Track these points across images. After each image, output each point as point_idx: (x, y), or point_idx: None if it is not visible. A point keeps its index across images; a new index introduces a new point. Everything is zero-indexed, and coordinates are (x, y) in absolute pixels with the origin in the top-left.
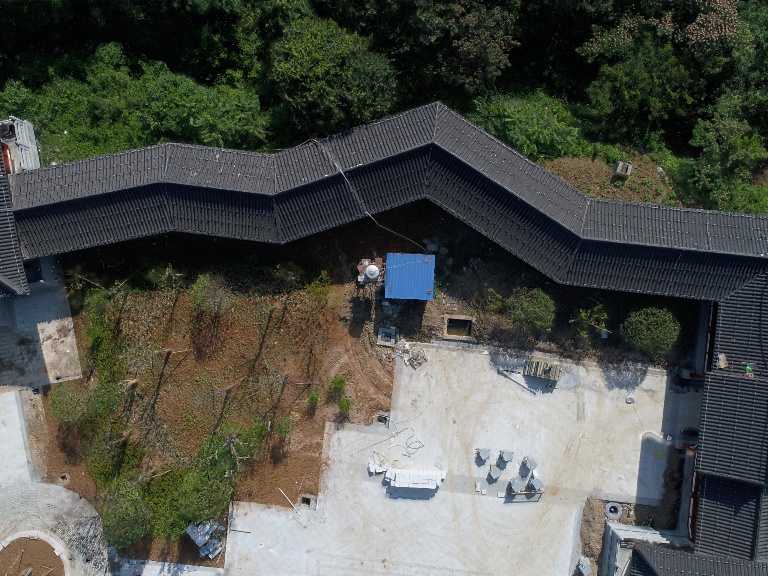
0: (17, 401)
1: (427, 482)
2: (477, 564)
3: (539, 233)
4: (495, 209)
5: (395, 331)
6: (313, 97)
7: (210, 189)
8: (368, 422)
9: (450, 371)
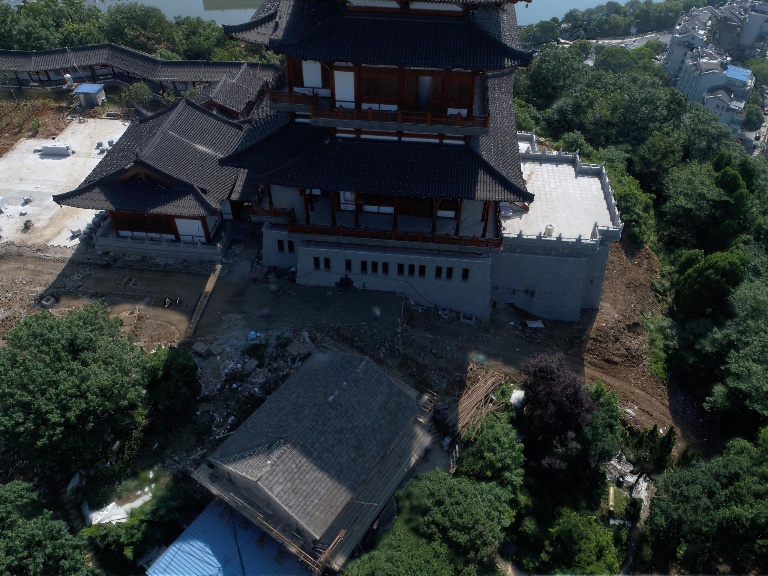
0: None
1: (61, 145)
2: (75, 179)
3: (147, 65)
4: (131, 61)
5: (77, 115)
6: (66, 34)
7: (7, 52)
8: (45, 138)
9: (98, 124)
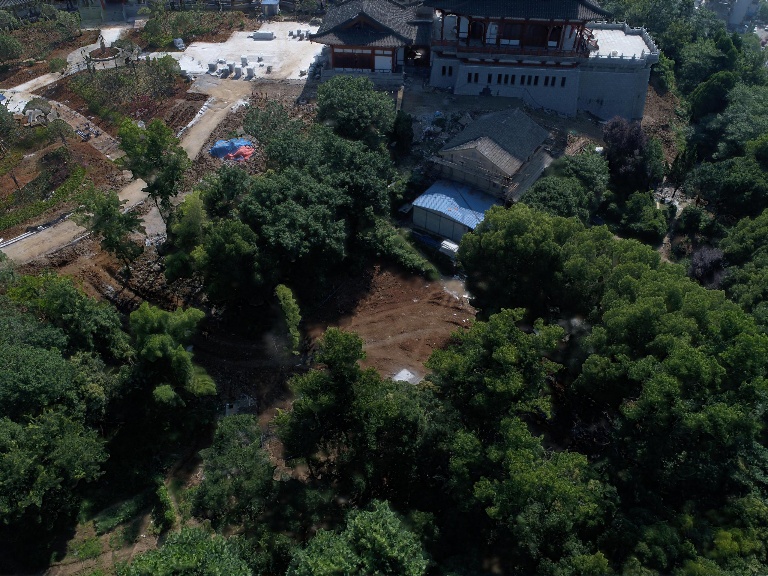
0: (120, 30)
1: None
2: (285, 50)
3: None
4: None
5: None
6: None
7: None
8: (250, 31)
9: None
